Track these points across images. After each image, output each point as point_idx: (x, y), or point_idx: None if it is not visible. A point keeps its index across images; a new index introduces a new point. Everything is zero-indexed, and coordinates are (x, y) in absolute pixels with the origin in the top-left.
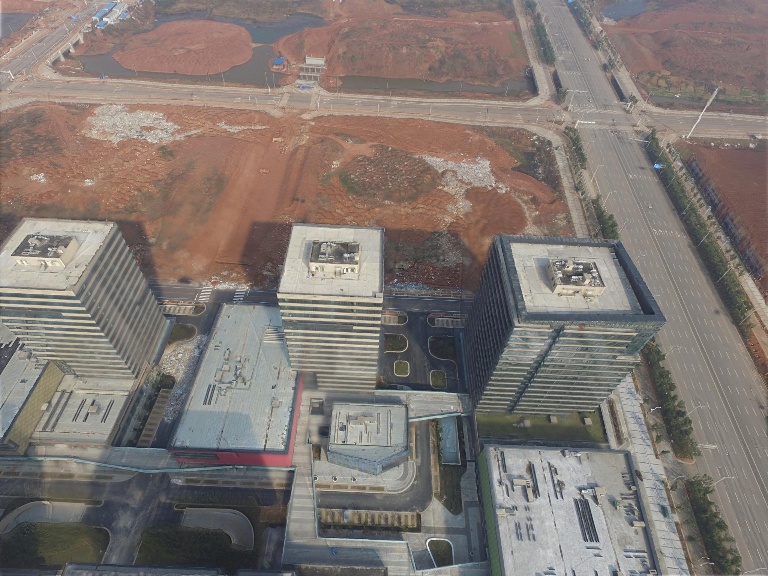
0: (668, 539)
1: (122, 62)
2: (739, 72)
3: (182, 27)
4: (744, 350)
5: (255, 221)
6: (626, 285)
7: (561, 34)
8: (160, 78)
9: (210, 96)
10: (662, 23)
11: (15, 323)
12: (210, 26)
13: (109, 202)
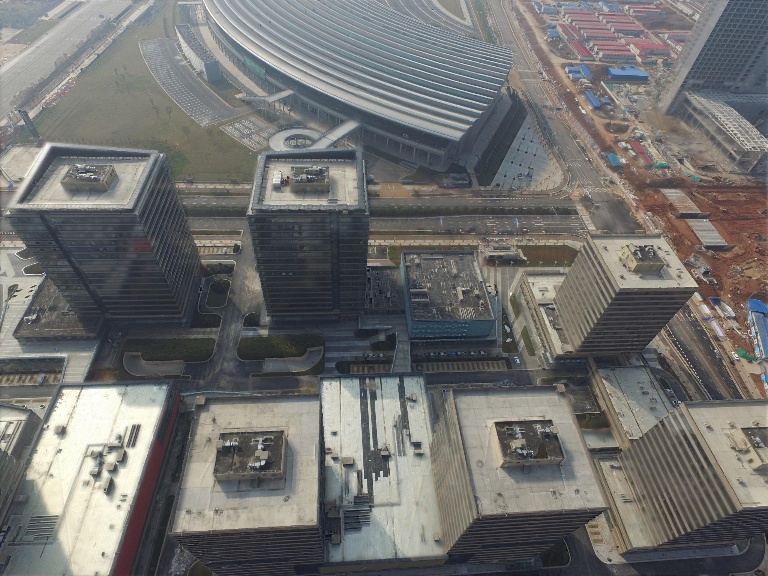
0: None
1: None
2: None
3: None
4: None
5: None
6: None
7: None
8: None
9: None
10: None
11: None
12: None
13: None
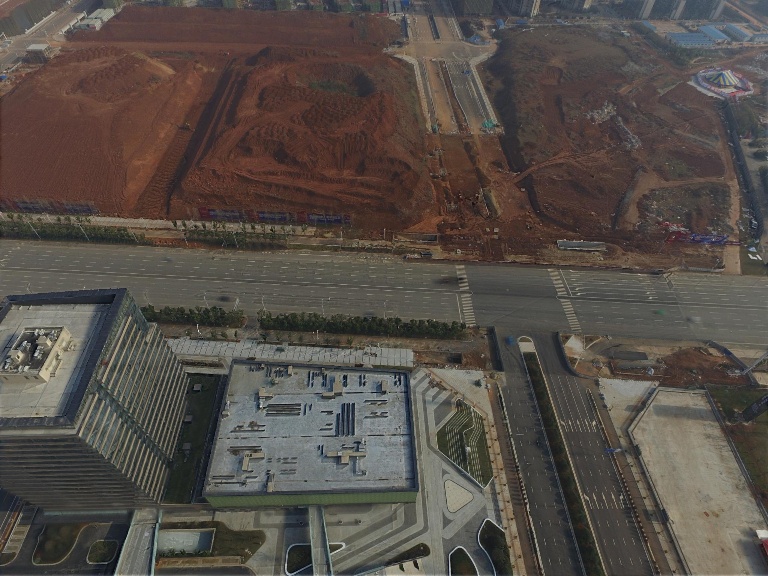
0: (300, 354)
1: None
2: None
3: None
4: (162, 249)
5: None
6: (69, 308)
7: None
8: None
9: None
10: None
11: None
12: None
13: None
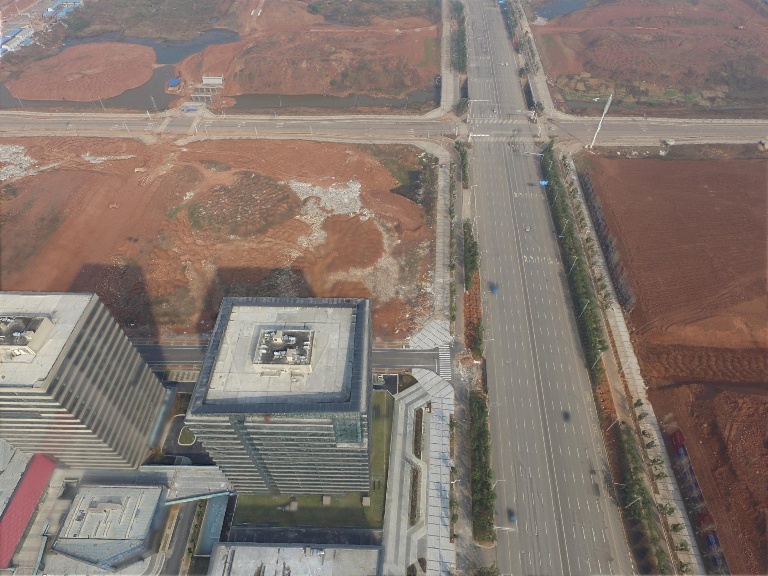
0: None
1: (12, 91)
2: (664, 71)
3: (85, 51)
4: (590, 400)
5: (85, 264)
6: (350, 358)
7: (484, 38)
8: (44, 107)
9: (86, 124)
10: (595, 20)
11: None
12: (114, 48)
13: None
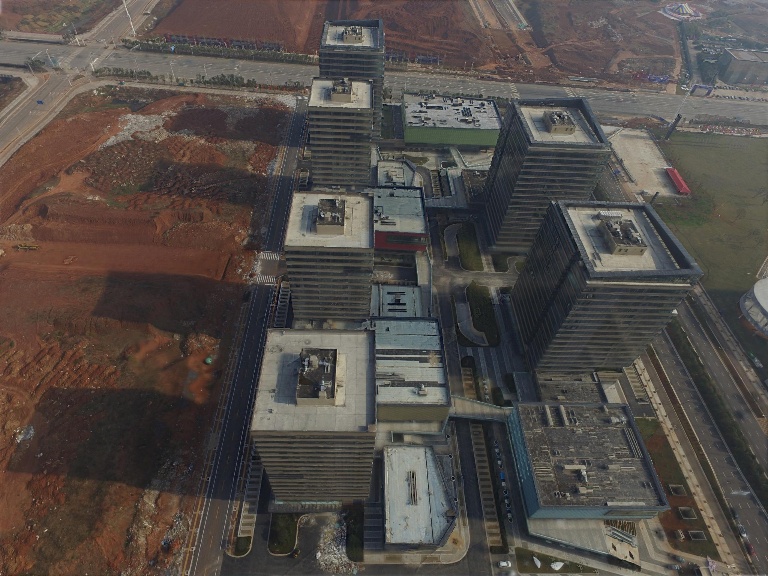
0: None
1: None
2: None
3: None
4: None
5: (166, 257)
6: None
7: None
8: None
9: None
10: None
11: None
12: None
13: (96, 386)
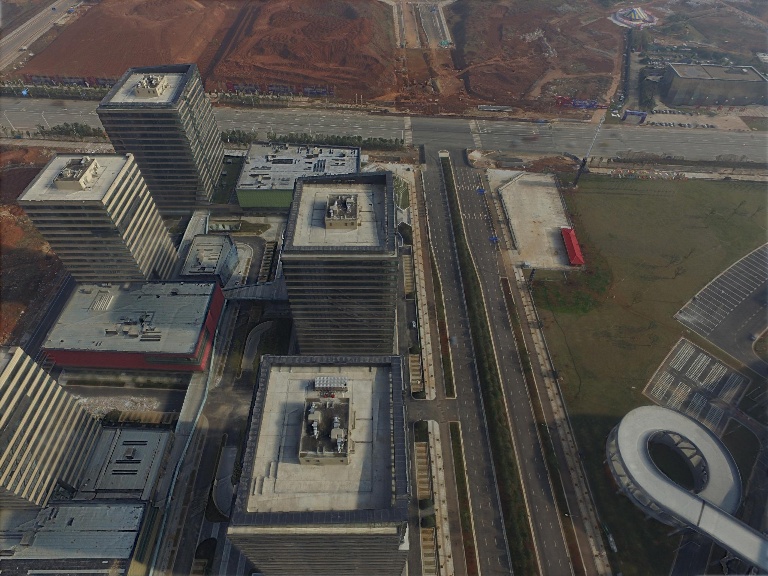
0: None
1: None
2: None
3: None
4: None
5: None
6: None
7: None
8: None
9: None
10: None
11: (6, 469)
12: None
13: None
